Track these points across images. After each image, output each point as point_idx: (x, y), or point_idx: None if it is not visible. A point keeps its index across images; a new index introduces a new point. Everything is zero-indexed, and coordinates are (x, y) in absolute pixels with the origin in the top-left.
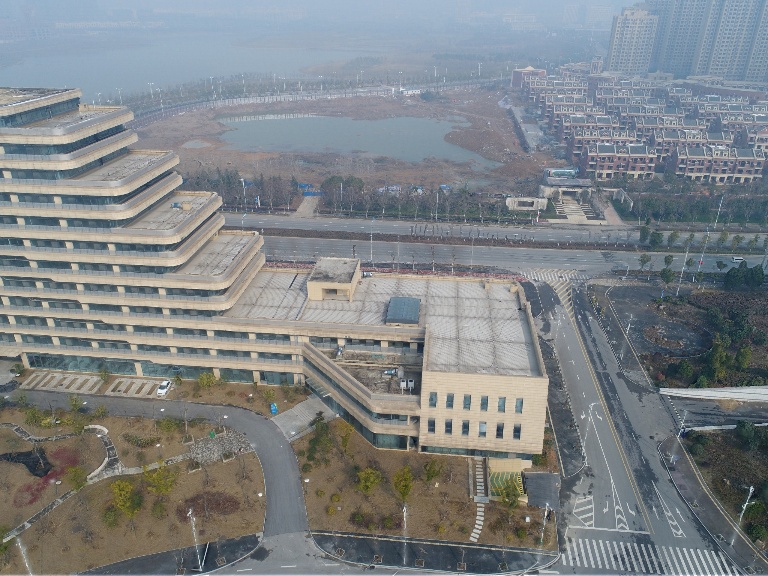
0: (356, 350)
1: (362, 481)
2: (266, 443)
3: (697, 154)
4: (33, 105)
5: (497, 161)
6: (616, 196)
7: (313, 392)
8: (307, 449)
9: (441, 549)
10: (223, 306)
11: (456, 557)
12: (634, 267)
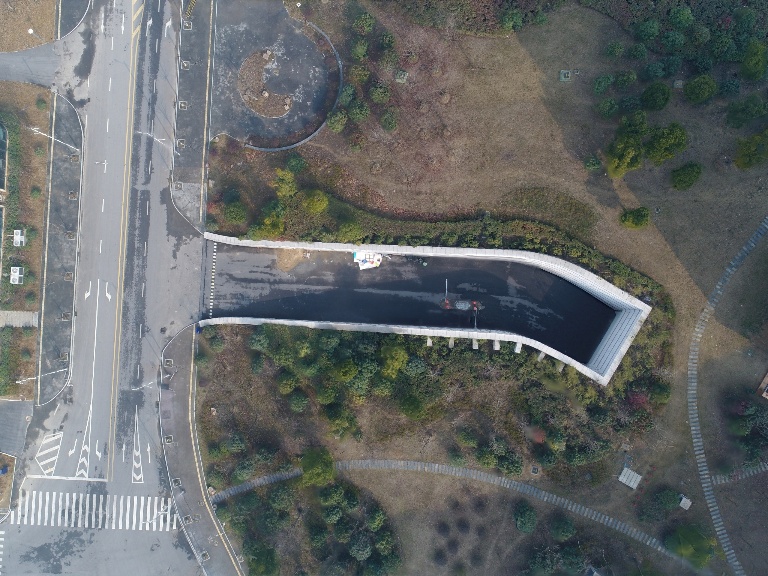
0: None
1: None
2: None
3: None
4: None
5: None
6: None
7: None
8: None
9: None
10: None
11: None
12: None
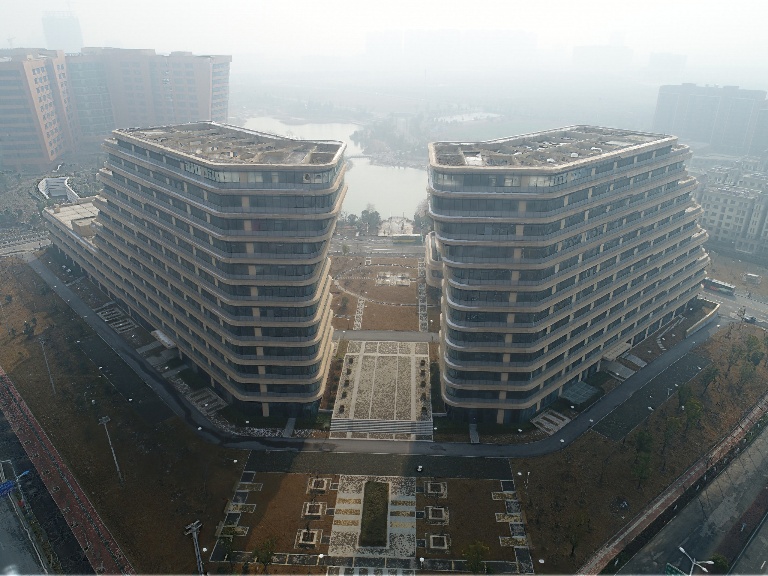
0: None
1: None
2: None
3: None
4: None
5: None
6: None
7: None
8: None
9: None
10: None
11: None
12: None
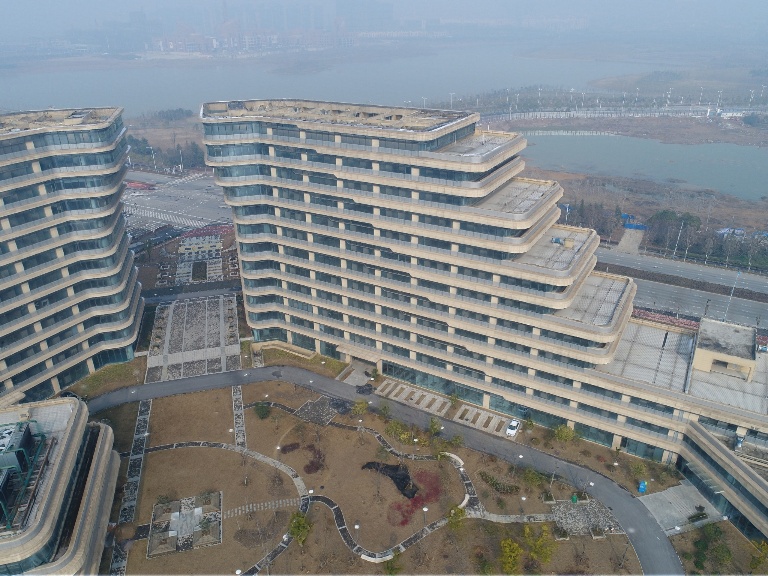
0: (759, 445)
1: None
2: (638, 528)
3: None
4: (448, 130)
5: None
6: None
7: (686, 477)
8: (692, 552)
9: None
10: (602, 360)
11: None
12: None
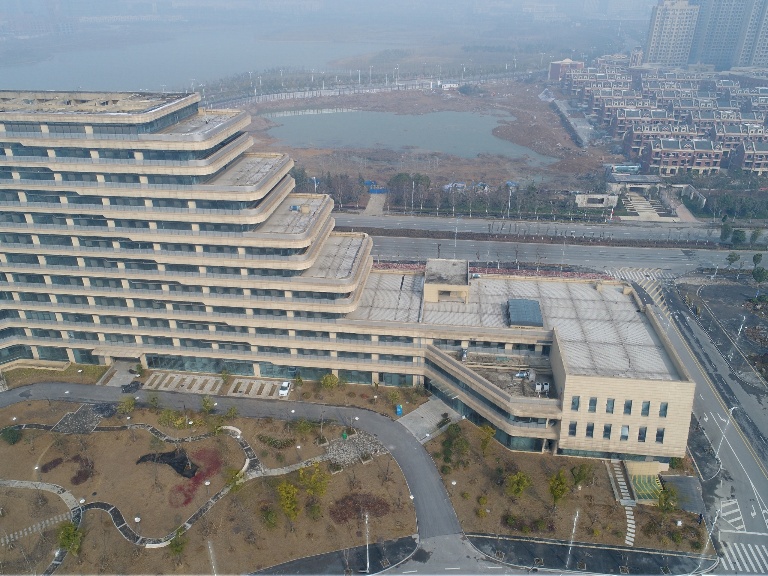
0: (479, 352)
1: (514, 484)
2: (399, 445)
3: (764, 149)
4: (167, 111)
5: (551, 156)
6: (684, 192)
7: (433, 393)
8: (441, 451)
9: (599, 552)
10: (349, 309)
11: (616, 560)
12: (719, 265)
